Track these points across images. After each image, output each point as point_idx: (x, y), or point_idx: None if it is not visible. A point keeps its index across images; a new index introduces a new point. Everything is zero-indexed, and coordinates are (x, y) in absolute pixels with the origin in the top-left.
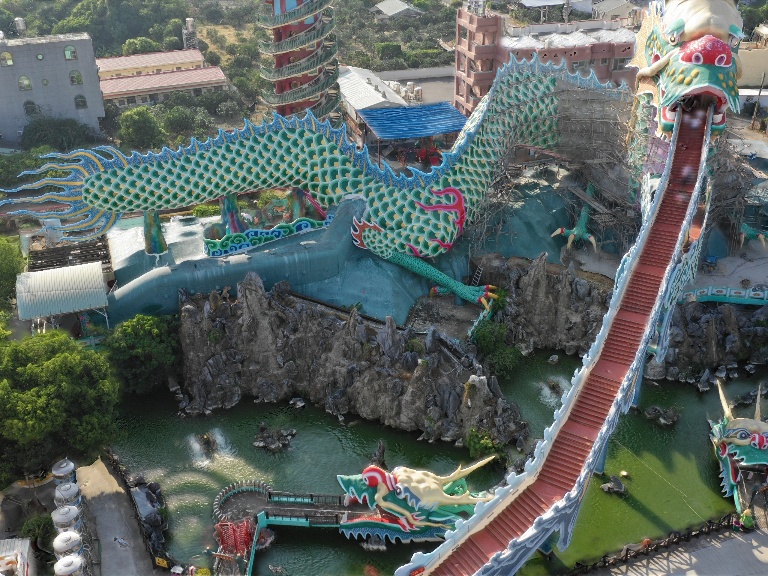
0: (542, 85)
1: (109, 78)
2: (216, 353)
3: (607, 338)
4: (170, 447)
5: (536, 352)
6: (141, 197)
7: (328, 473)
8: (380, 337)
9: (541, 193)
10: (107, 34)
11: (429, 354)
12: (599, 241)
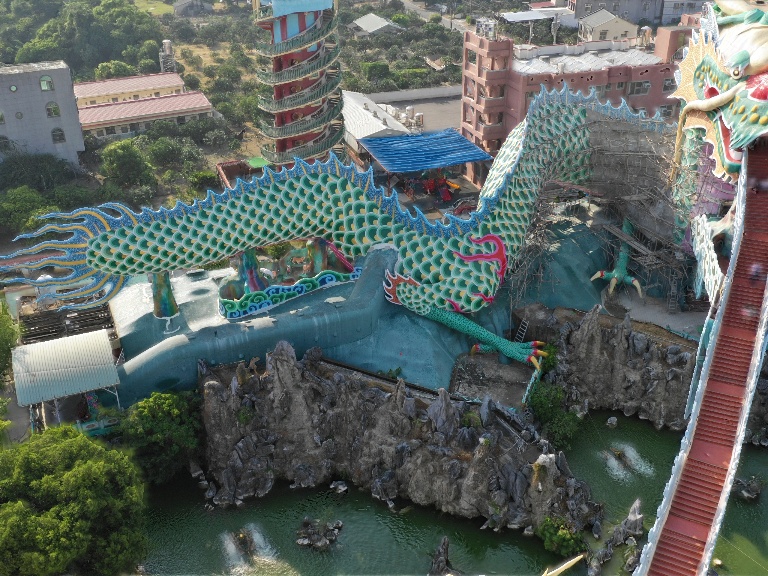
0: (573, 117)
1: (85, 107)
2: (246, 434)
3: (699, 414)
4: (200, 549)
5: (591, 414)
6: (153, 258)
7: (385, 574)
8: (432, 411)
9: (575, 232)
10: (76, 57)
11: (486, 428)
12: (644, 285)
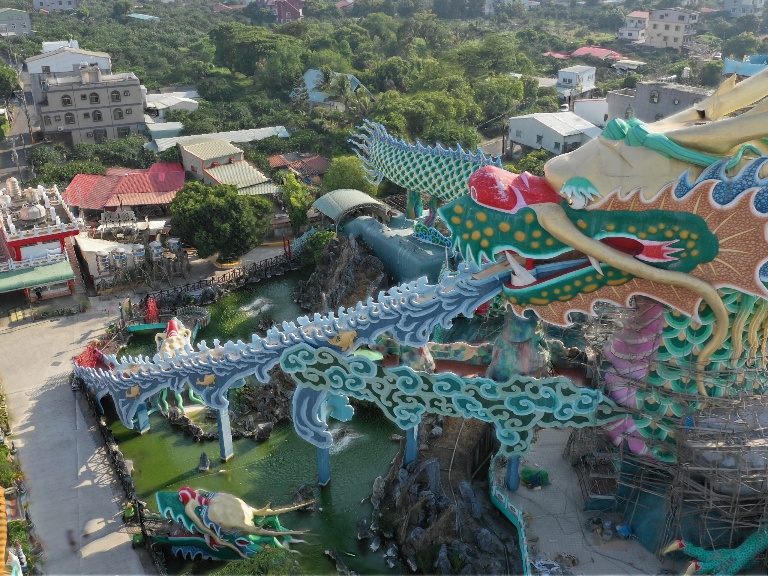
0: None
1: None
2: None
3: None
4: None
5: None
6: None
7: None
8: None
9: None
10: None
11: None
12: None
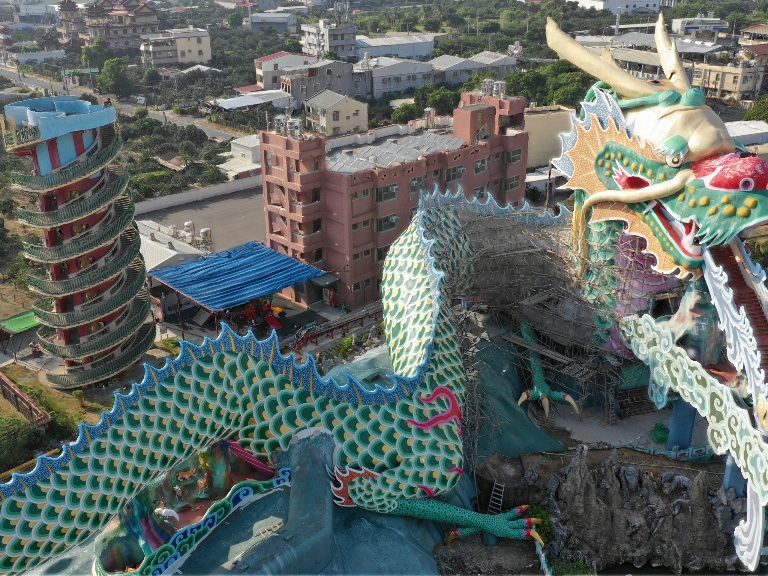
0: (449, 221)
1: None
2: None
3: None
4: None
5: None
6: (14, 561)
7: None
8: None
9: (481, 352)
10: None
11: None
12: (577, 399)
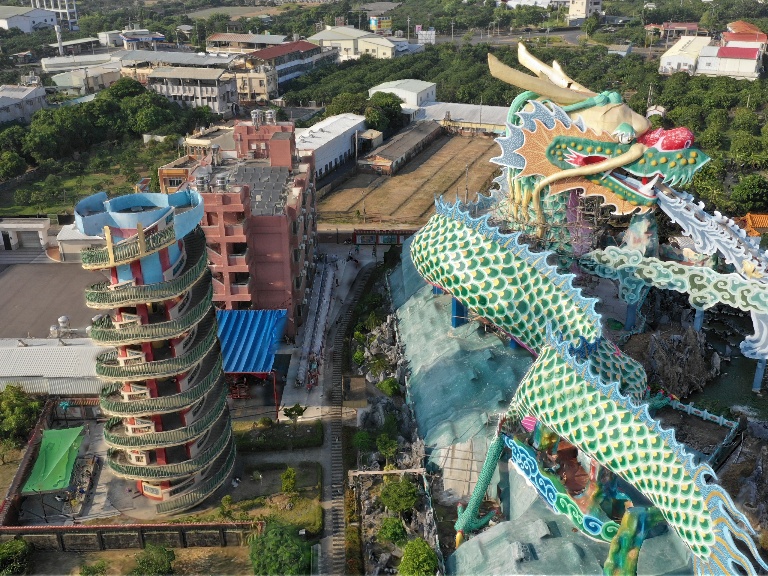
0: None
1: None
2: None
3: None
4: None
5: None
6: None
7: None
8: None
9: None
10: None
11: None
12: None
